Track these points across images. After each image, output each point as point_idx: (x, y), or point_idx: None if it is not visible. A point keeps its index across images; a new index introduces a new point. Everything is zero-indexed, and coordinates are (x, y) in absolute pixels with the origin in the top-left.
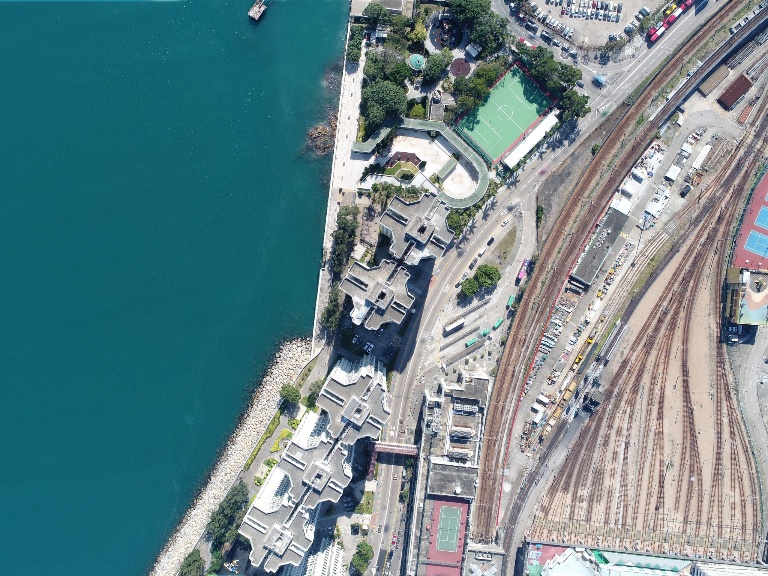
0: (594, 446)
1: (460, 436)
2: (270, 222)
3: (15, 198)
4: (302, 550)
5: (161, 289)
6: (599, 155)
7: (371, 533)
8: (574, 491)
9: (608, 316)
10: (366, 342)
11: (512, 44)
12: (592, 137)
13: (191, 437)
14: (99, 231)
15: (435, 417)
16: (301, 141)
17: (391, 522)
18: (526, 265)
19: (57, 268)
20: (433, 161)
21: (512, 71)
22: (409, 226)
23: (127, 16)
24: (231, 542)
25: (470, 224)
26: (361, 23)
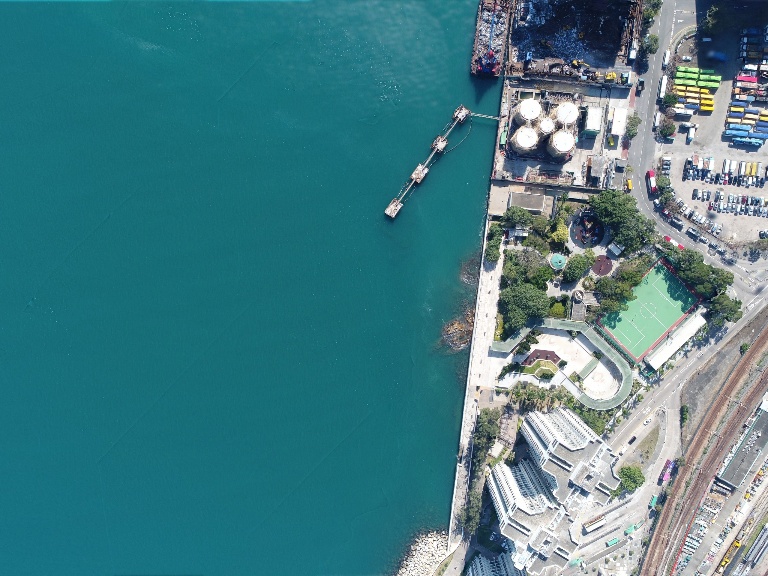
0: None
1: None
2: (405, 416)
3: (165, 408)
4: None
5: (306, 497)
6: (748, 354)
7: None
8: None
9: (756, 517)
10: (503, 539)
11: (657, 242)
12: (740, 335)
13: None
14: (245, 440)
15: None
16: (436, 335)
17: None
18: (671, 467)
19: (205, 476)
20: (573, 359)
21: (656, 268)
22: (574, 474)
23: (273, 231)
24: None
25: (611, 423)
26: (499, 221)
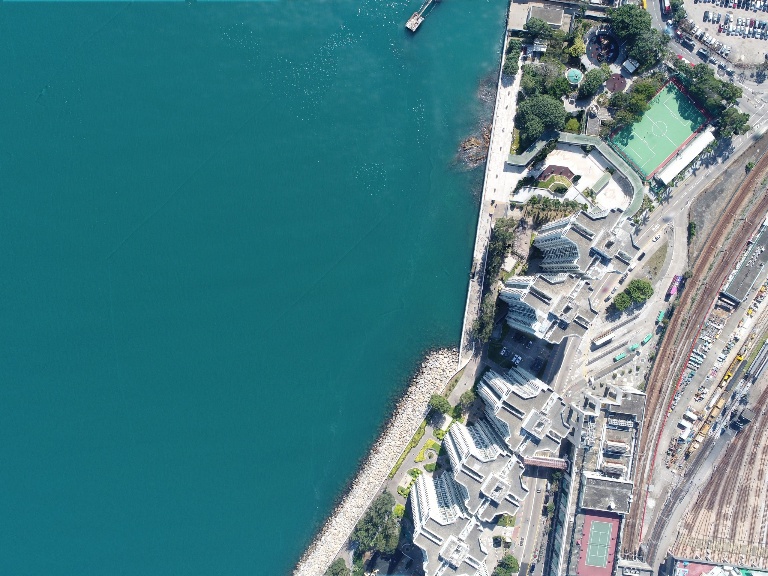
0: (740, 464)
1: (615, 451)
2: (420, 232)
3: (180, 203)
4: (477, 563)
5: (321, 297)
6: (753, 173)
7: (513, 546)
8: (719, 509)
9: (757, 334)
10: (514, 354)
11: (670, 61)
12: (746, 155)
13: (334, 445)
14: (261, 238)
15: (589, 431)
16: (453, 152)
17: (533, 535)
18: (678, 281)
19: (219, 274)
20: (586, 175)
21: (667, 87)
22: (596, 241)
23: (297, 26)
24: (372, 551)
25: None
26: (518, 37)
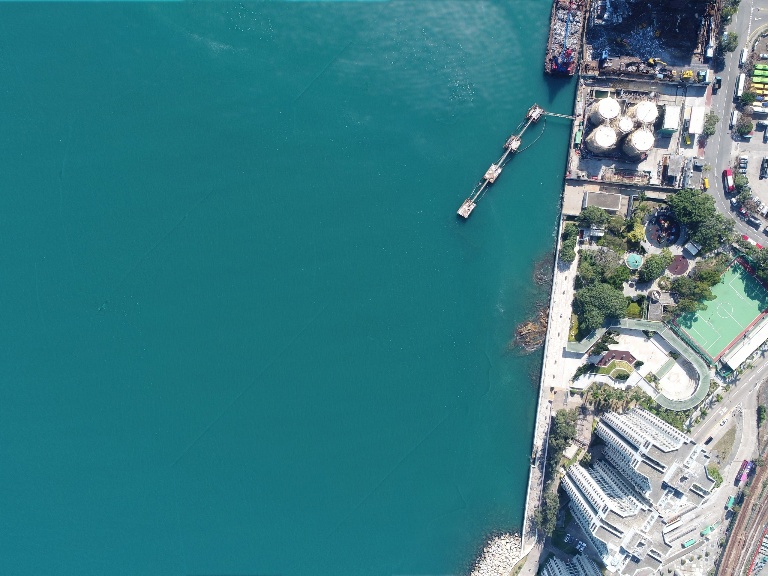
0: None
1: None
2: (478, 418)
3: (240, 411)
4: None
5: (383, 500)
6: None
7: None
8: None
9: None
10: (578, 541)
11: None
12: None
13: None
14: (321, 442)
15: None
16: (509, 336)
17: None
18: (749, 468)
19: (281, 479)
20: (648, 359)
21: (732, 267)
22: (669, 476)
23: (350, 232)
24: None
25: (687, 423)
26: (574, 221)
